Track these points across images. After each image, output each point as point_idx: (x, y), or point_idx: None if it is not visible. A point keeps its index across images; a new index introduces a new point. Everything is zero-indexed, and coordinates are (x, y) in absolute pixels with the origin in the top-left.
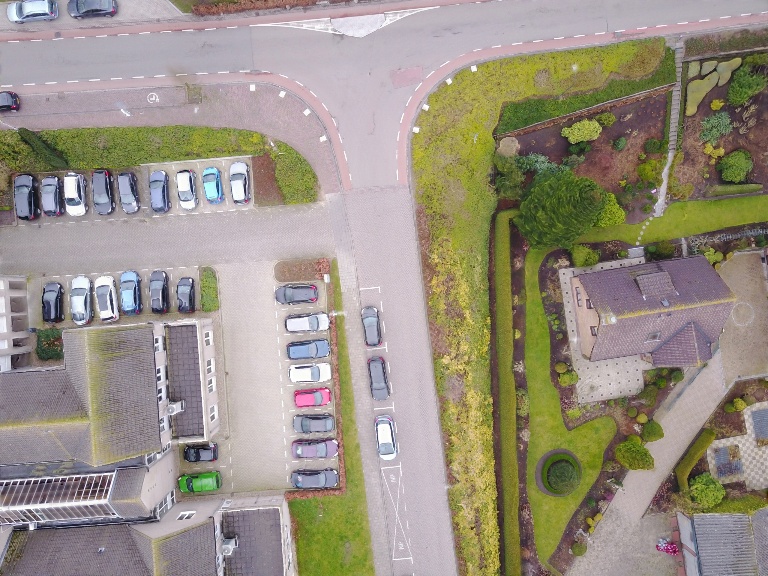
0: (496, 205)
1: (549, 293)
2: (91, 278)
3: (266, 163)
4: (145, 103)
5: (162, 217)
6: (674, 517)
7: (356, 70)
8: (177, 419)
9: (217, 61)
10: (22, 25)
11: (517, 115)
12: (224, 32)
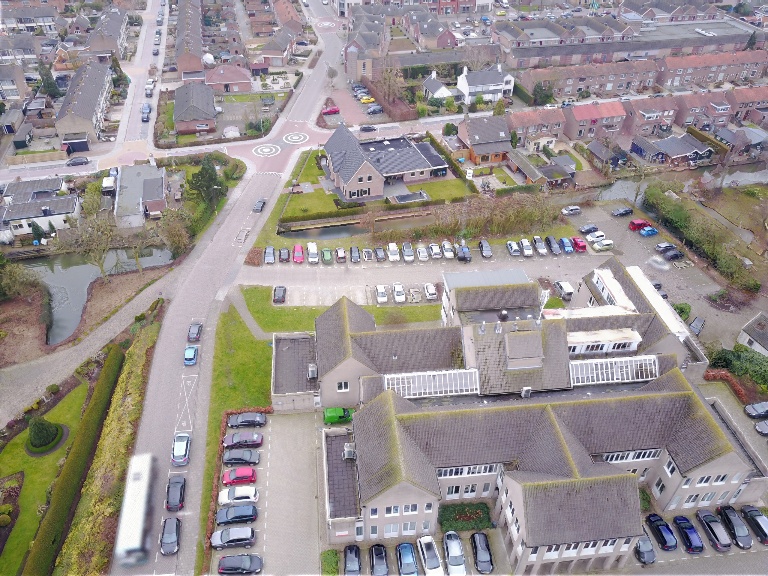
0: None
1: None
2: None
3: None
4: None
5: None
6: None
7: None
8: None
9: None
10: None
11: None
12: None
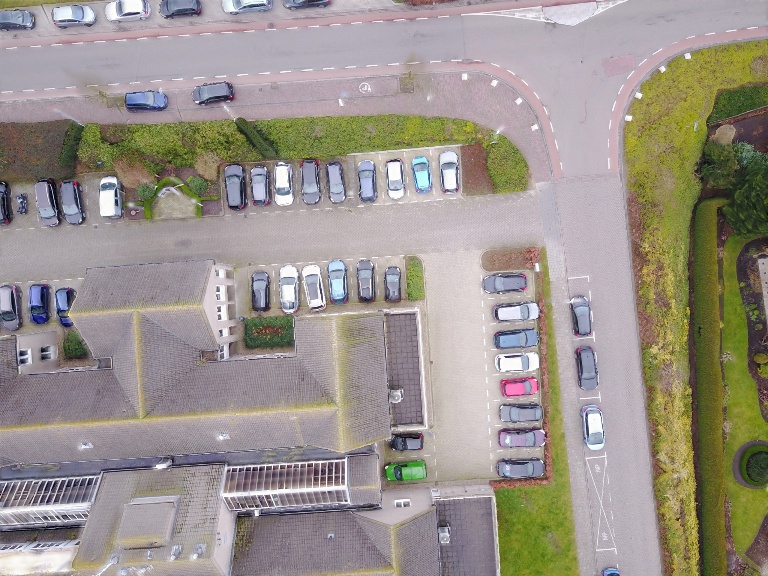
0: (699, 194)
1: (748, 283)
2: (297, 267)
3: (477, 152)
4: (357, 93)
5: (367, 207)
6: None
7: (568, 58)
8: (395, 407)
9: (429, 50)
10: (235, 16)
11: (731, 103)
12: (436, 21)
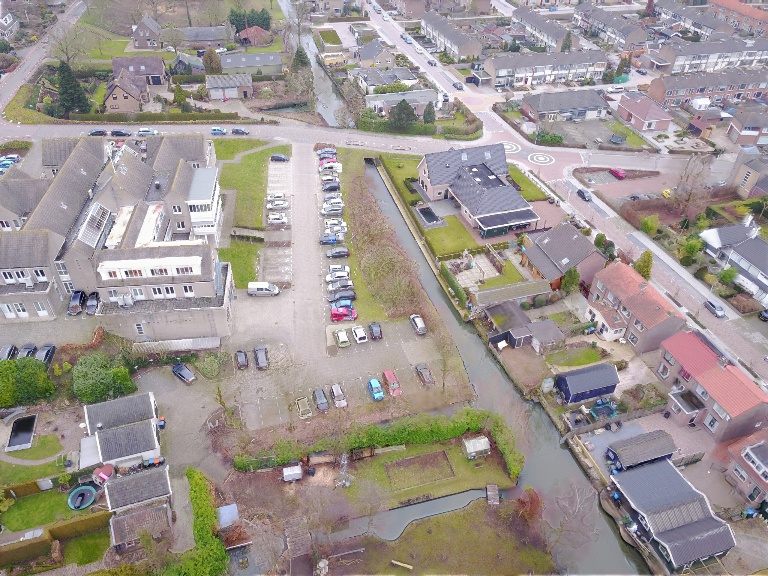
0: None
1: None
2: None
3: (6, 151)
4: None
5: None
6: (214, 100)
7: None
8: None
9: None
10: None
11: None
12: None
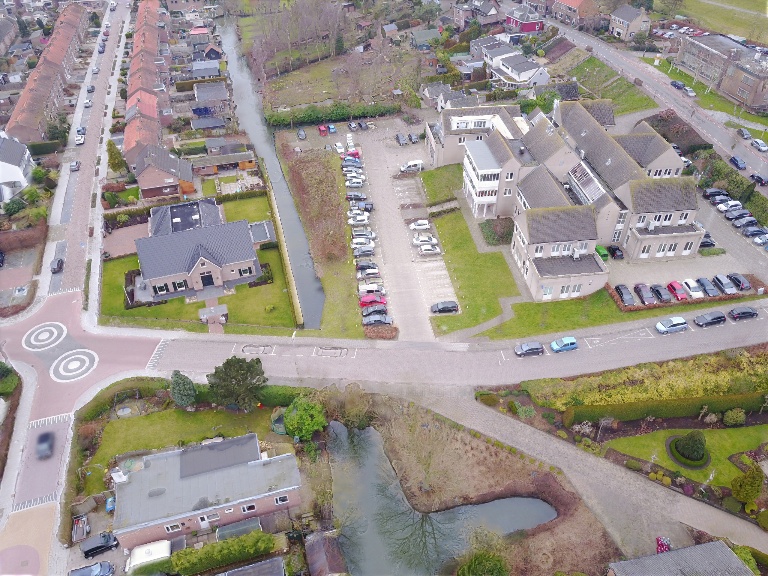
0: None
1: None
2: None
3: None
4: None
5: (740, 236)
6: None
7: None
8: (642, 230)
9: None
10: None
11: None
12: None
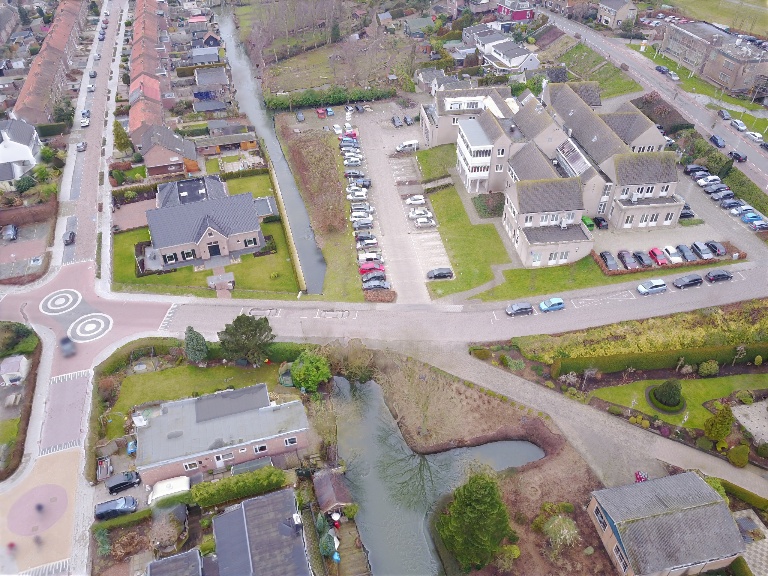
0: None
1: None
2: None
3: None
4: None
5: (718, 208)
6: None
7: None
8: (626, 202)
9: None
10: None
11: None
12: None
